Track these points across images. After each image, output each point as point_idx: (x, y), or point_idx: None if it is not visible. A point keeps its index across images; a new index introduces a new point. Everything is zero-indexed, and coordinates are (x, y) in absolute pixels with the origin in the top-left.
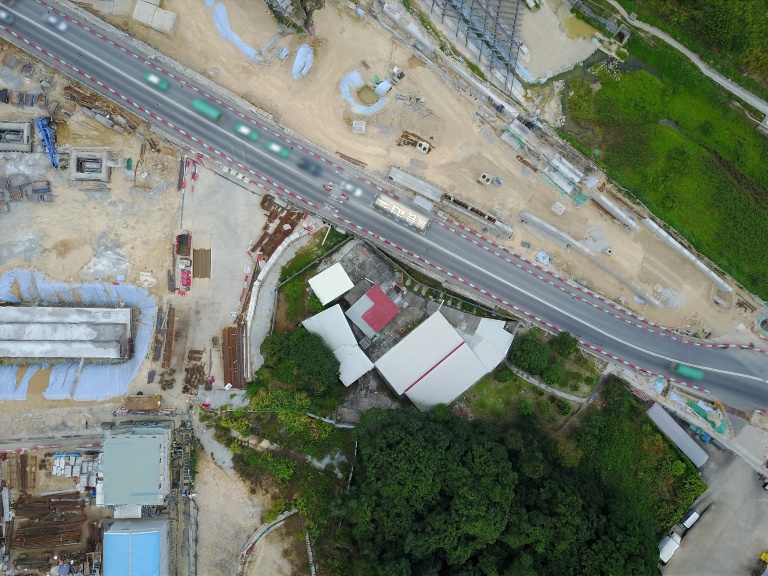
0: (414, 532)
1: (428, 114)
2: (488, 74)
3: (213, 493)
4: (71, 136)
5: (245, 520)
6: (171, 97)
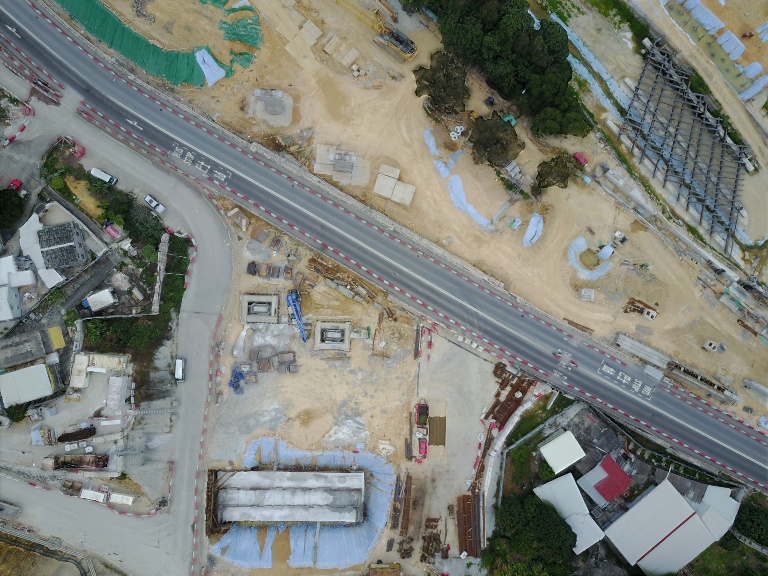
0: None
1: (651, 279)
2: (706, 236)
3: None
4: (313, 306)
5: None
6: (408, 267)
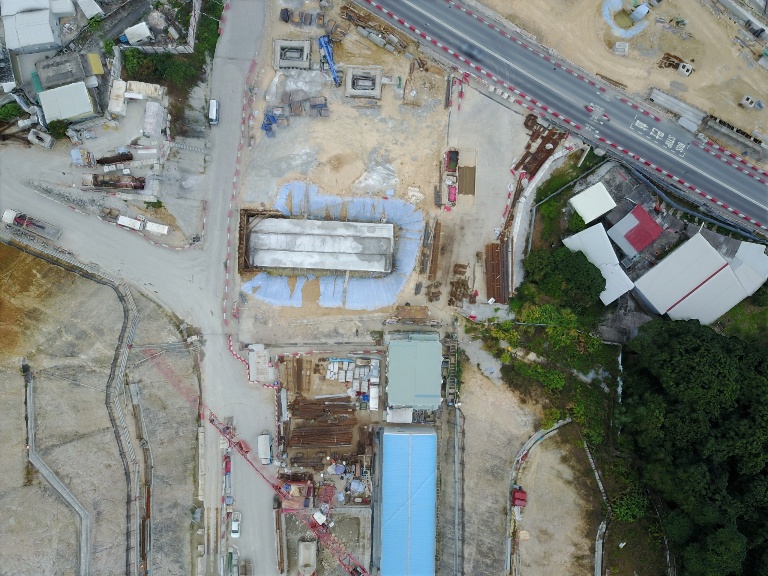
0: (714, 437)
1: (687, 37)
2: None
3: (481, 402)
4: (344, 55)
5: (517, 428)
6: (439, 17)
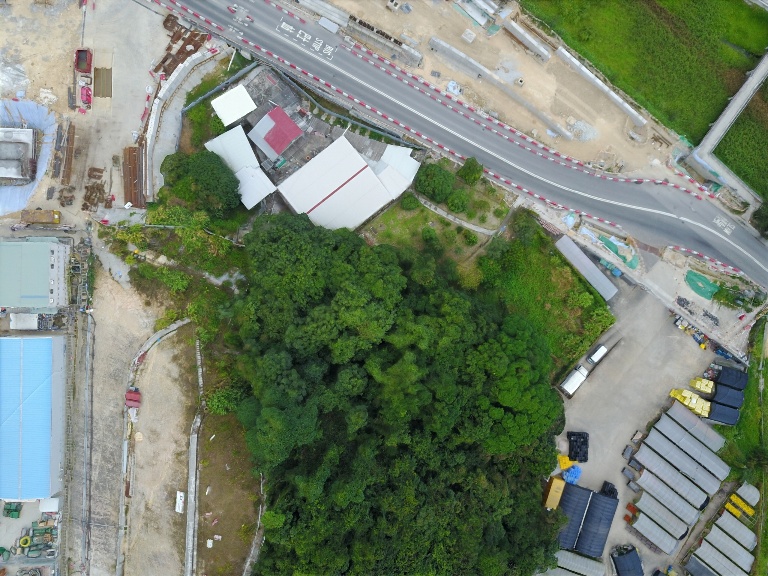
0: (295, 325)
1: None
2: None
3: (110, 307)
4: None
5: (139, 330)
6: None
